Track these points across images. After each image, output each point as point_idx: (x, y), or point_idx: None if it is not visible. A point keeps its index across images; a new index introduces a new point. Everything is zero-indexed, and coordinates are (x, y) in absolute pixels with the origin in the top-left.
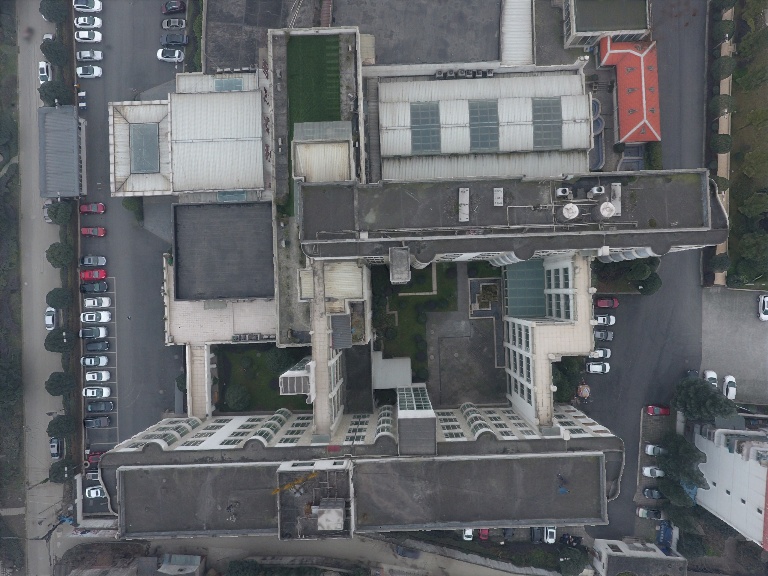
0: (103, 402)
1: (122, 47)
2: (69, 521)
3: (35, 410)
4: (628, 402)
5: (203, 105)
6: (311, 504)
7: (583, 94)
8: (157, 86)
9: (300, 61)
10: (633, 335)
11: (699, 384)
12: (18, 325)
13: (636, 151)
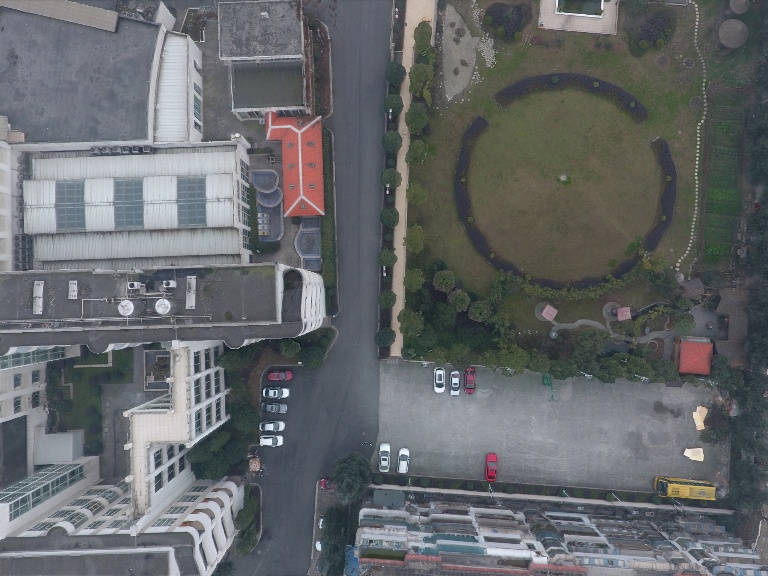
0: None
1: None
2: None
3: None
4: (303, 475)
5: None
6: None
7: (236, 171)
8: None
9: None
10: (309, 407)
11: (345, 463)
12: None
13: (317, 222)
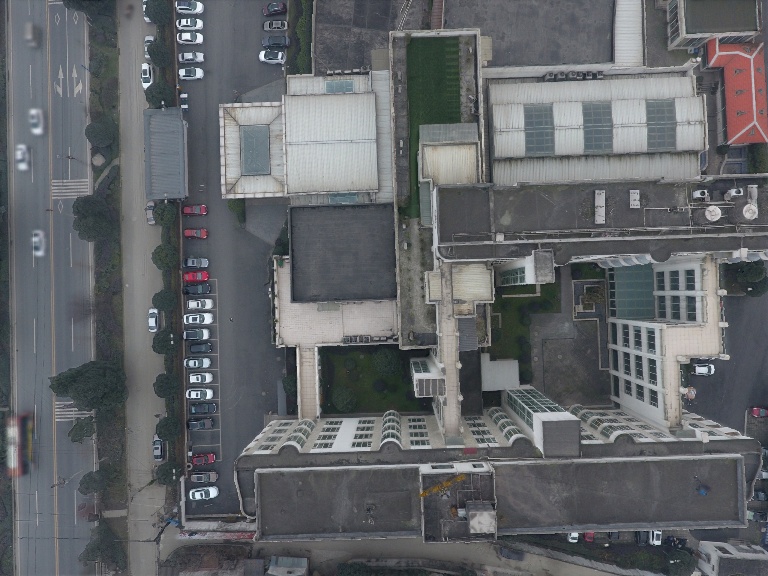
0: (206, 404)
1: (223, 49)
2: (175, 523)
3: (137, 412)
4: (732, 404)
5: (317, 107)
6: (456, 507)
7: (694, 96)
8: (258, 88)
9: (420, 63)
10: (737, 337)
11: None
12: (120, 327)
13: (738, 153)
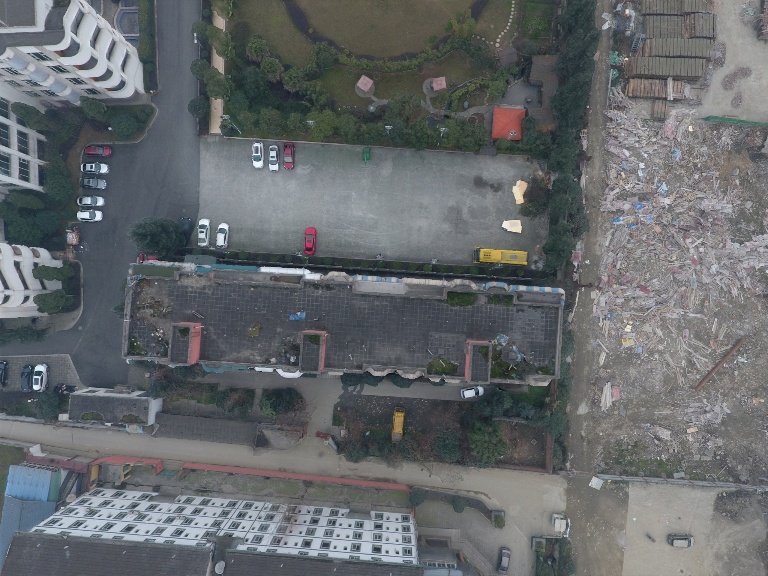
0: None
1: None
2: None
3: None
4: (124, 251)
5: None
6: None
7: None
8: None
9: None
10: (129, 184)
11: None
12: None
13: None
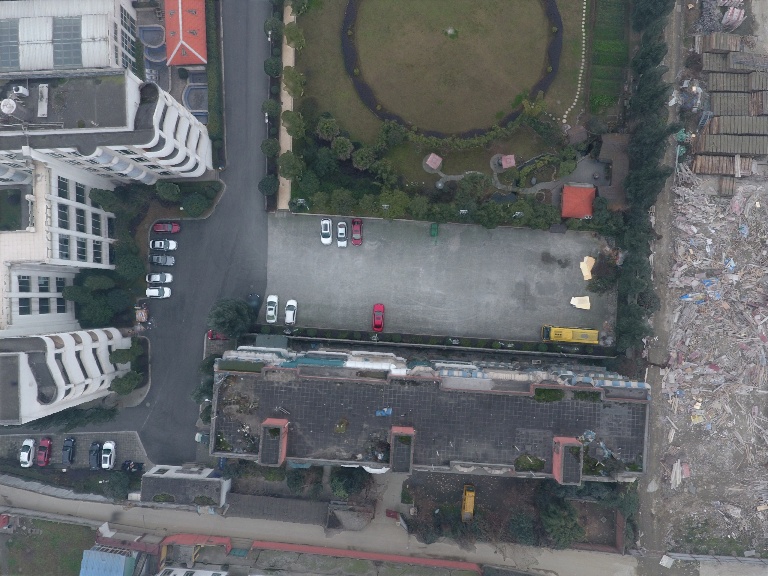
0: None
1: None
2: None
3: None
4: (192, 327)
5: None
6: None
7: (114, 15)
8: None
9: None
10: (197, 260)
11: None
12: None
13: (205, 78)
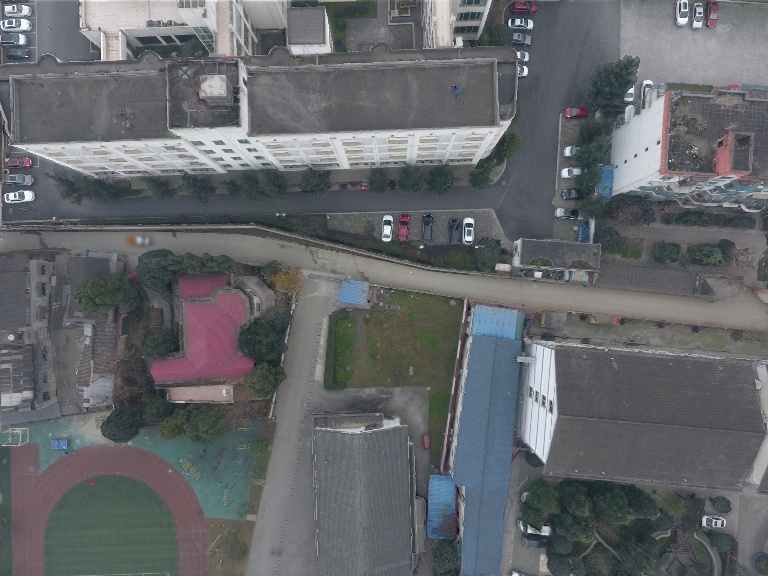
0: None
1: None
2: None
3: None
4: (547, 107)
5: None
6: None
7: None
8: None
9: None
10: (552, 41)
11: (610, 62)
12: None
13: None
